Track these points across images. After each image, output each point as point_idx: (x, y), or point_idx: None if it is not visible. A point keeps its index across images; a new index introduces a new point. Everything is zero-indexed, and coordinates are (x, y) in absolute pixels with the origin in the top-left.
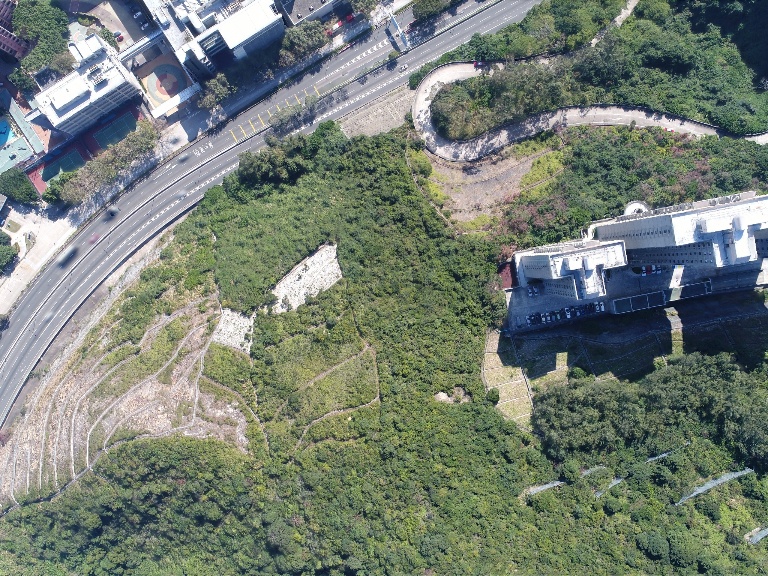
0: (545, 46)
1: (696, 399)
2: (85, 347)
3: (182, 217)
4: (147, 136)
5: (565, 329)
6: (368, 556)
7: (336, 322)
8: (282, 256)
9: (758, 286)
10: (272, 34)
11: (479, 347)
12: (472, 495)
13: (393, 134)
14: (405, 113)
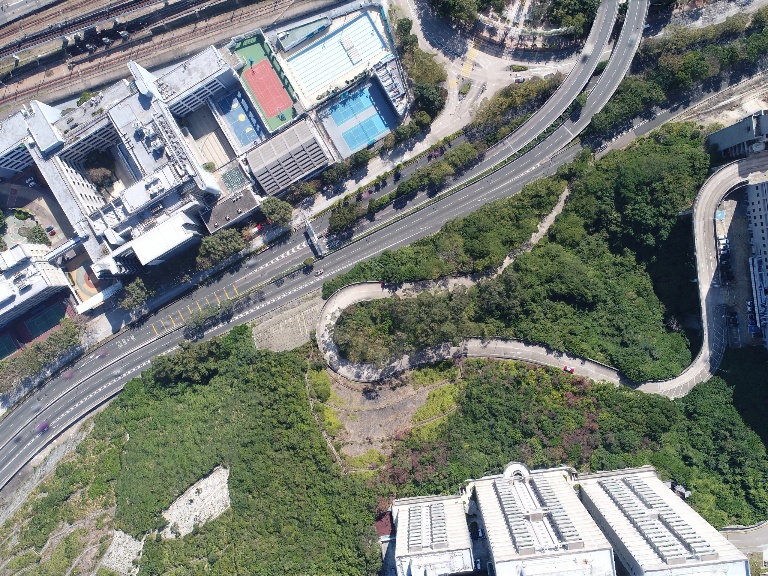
0: (454, 267)
1: None
2: None
3: (104, 404)
4: (69, 335)
5: None
6: None
7: (217, 558)
8: (178, 475)
9: None
10: (188, 243)
11: None
12: None
13: (296, 353)
14: (312, 328)
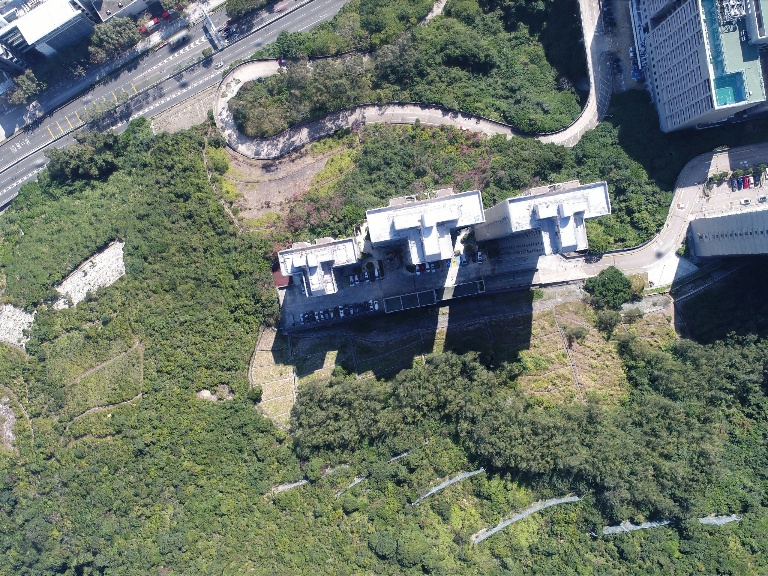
0: (351, 44)
1: (432, 398)
2: None
3: None
4: None
5: (340, 327)
6: (113, 553)
7: (111, 319)
8: (72, 252)
9: (534, 286)
10: (79, 30)
11: (248, 345)
12: (217, 493)
13: (193, 131)
14: None
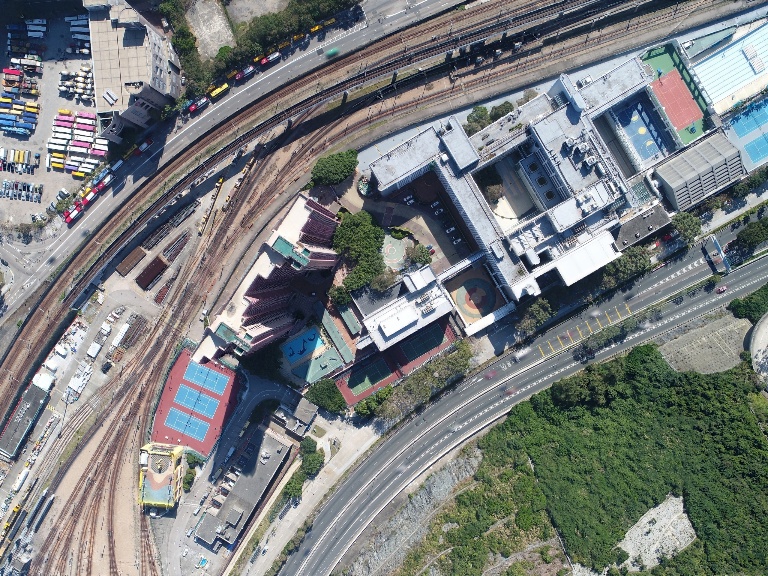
0: None
1: None
2: (411, 575)
3: (484, 429)
4: (466, 358)
5: None
6: None
7: None
8: (625, 505)
9: None
10: None
11: None
12: None
13: (732, 375)
14: (738, 349)
